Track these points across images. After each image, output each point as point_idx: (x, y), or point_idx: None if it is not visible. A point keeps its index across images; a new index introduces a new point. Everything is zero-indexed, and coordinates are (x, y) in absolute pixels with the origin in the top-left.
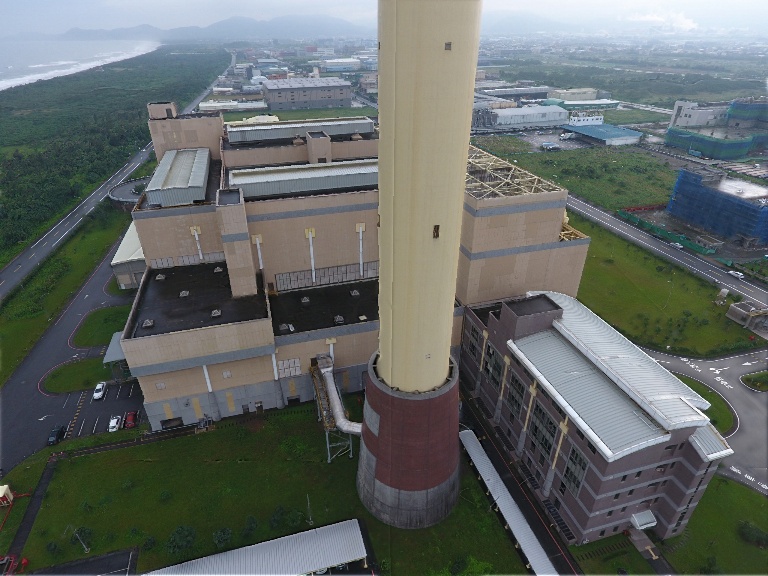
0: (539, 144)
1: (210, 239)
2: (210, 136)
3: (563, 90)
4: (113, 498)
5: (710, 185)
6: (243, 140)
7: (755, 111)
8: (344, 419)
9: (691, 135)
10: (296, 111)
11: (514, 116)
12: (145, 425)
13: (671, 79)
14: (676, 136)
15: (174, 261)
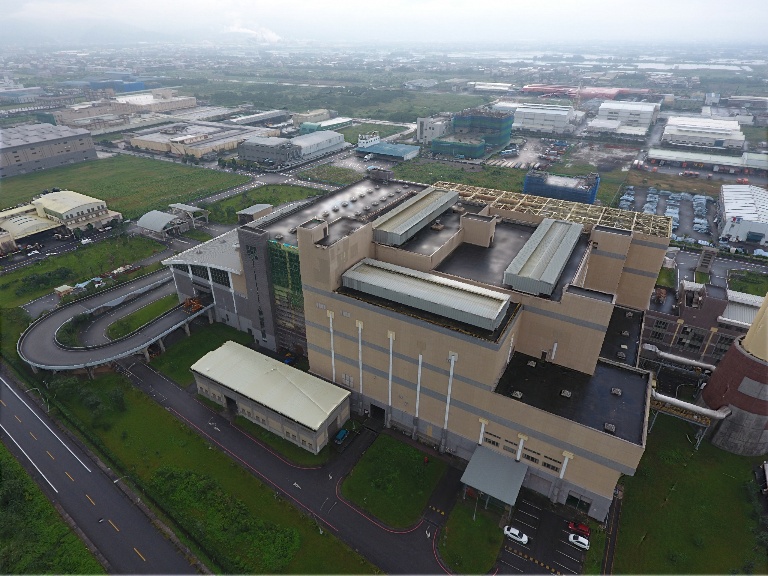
0: (358, 168)
1: (513, 340)
2: (364, 244)
3: (306, 113)
4: (685, 575)
5: (547, 183)
6: (406, 239)
7: (469, 121)
8: (717, 411)
9: (451, 144)
10: (34, 175)
11: (312, 146)
12: (592, 524)
13: (339, 92)
14: (439, 145)
15: (499, 375)
